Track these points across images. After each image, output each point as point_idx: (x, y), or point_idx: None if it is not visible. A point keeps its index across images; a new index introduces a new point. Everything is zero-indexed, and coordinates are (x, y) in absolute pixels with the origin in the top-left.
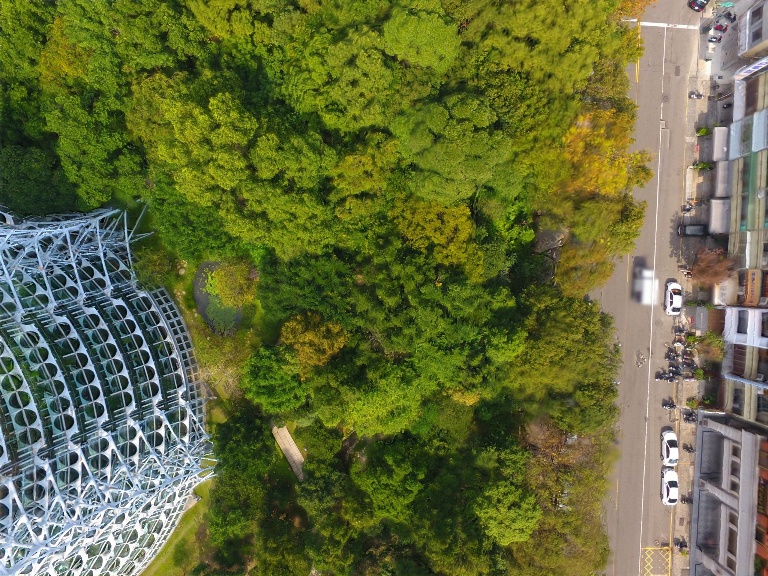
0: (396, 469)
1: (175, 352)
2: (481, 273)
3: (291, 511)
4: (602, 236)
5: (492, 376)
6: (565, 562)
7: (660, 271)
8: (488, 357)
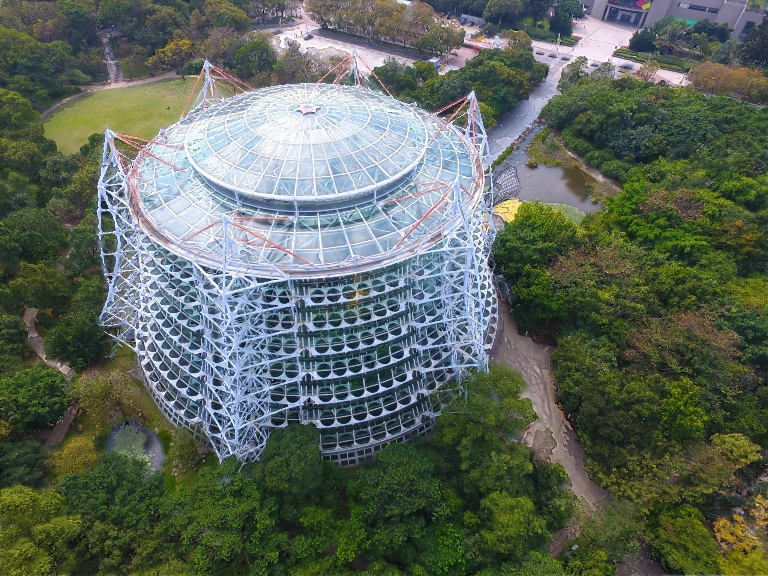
0: None
1: (154, 386)
2: None
3: None
4: None
5: None
6: None
7: None
8: None
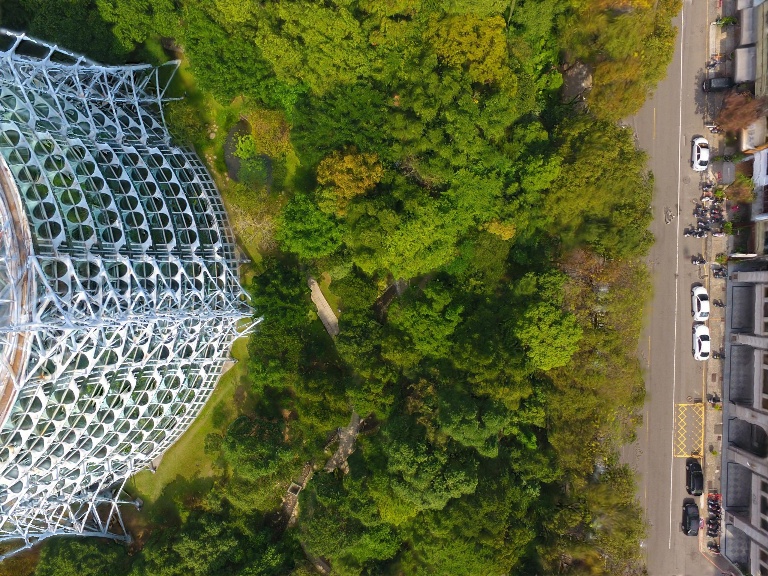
0: (436, 297)
1: (210, 208)
2: None
3: (327, 371)
4: (636, 49)
5: (528, 204)
6: (606, 383)
7: (686, 128)
8: (523, 188)
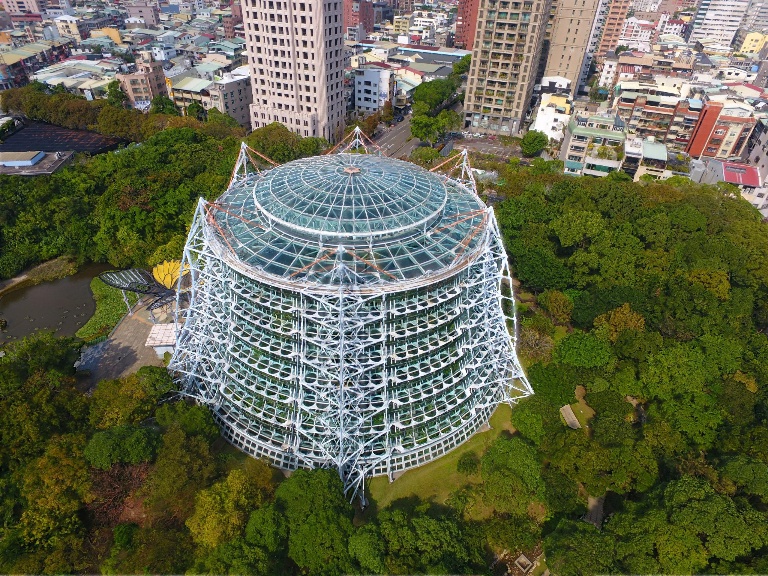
0: (698, 393)
1: None
2: (738, 323)
3: None
4: None
5: None
6: None
7: None
8: None
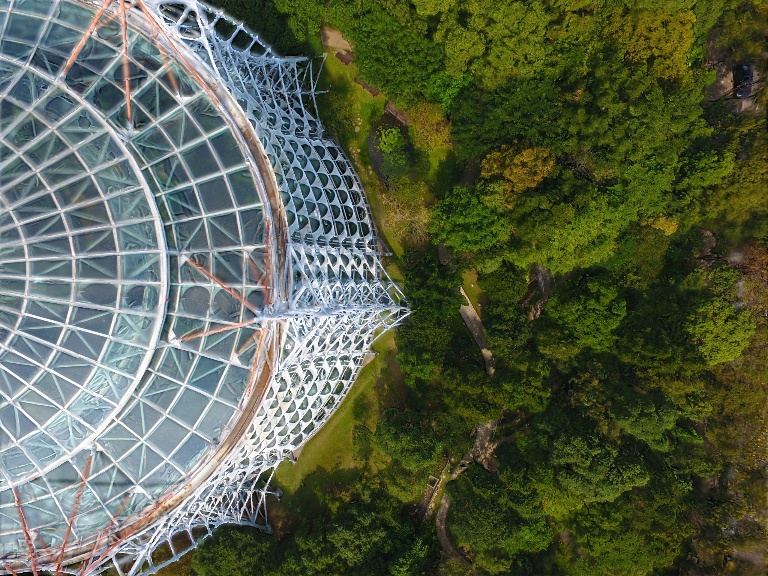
0: (606, 291)
1: (361, 201)
2: None
3: None
4: None
5: (697, 200)
6: None
7: None
8: (690, 184)
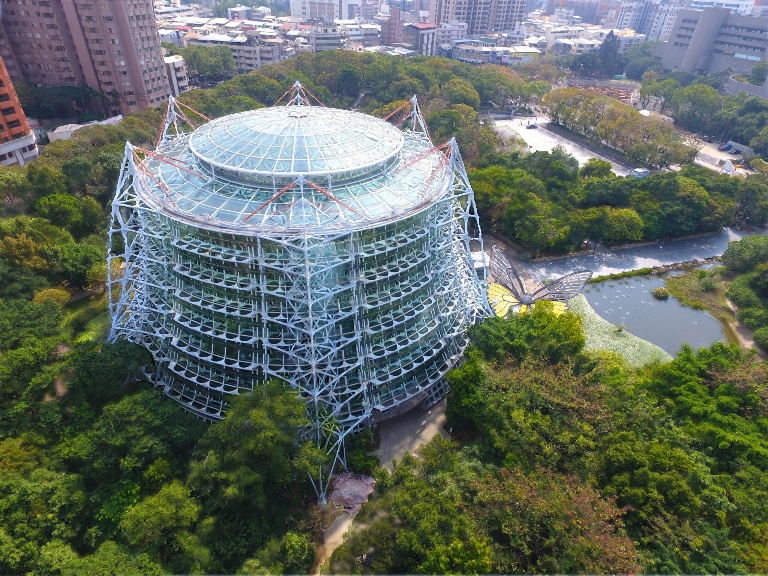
0: (42, 202)
1: None
2: None
3: None
4: None
5: None
6: None
7: None
8: None
